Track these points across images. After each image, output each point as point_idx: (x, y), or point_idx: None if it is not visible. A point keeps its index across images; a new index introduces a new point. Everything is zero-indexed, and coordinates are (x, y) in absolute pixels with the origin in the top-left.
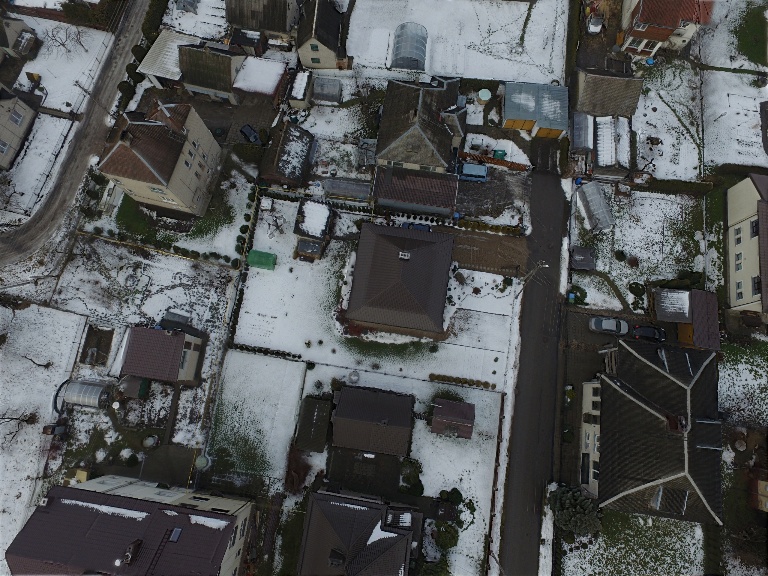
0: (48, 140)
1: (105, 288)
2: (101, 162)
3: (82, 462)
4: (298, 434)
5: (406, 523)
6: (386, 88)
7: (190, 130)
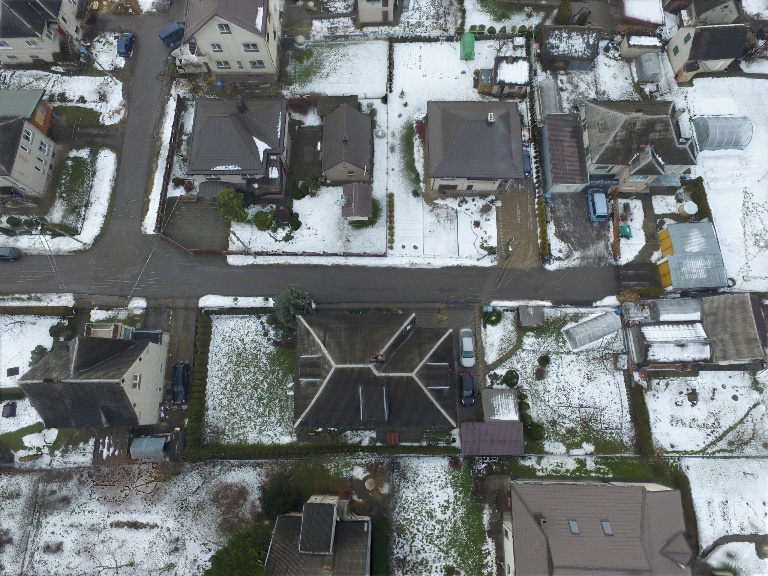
0: None
1: None
2: None
3: None
4: (329, 96)
5: (271, 174)
6: None
7: None
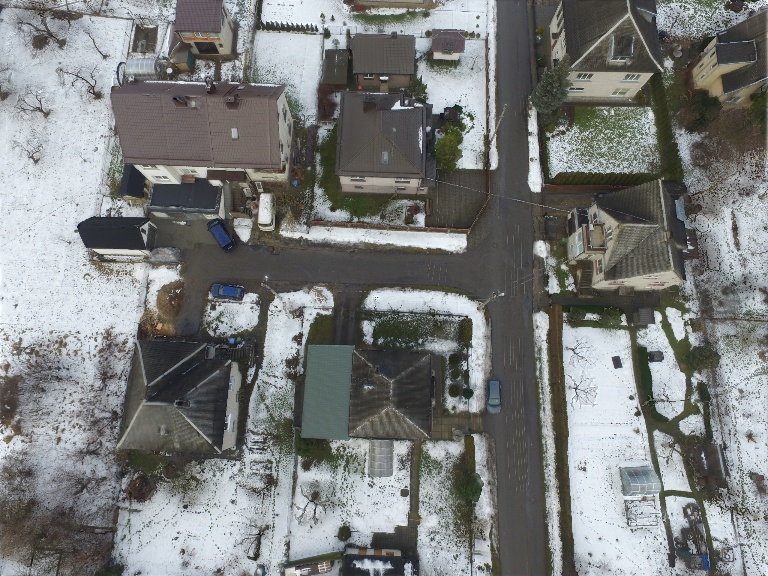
0: None
1: None
2: None
3: None
4: (324, 74)
5: None
6: None
7: None
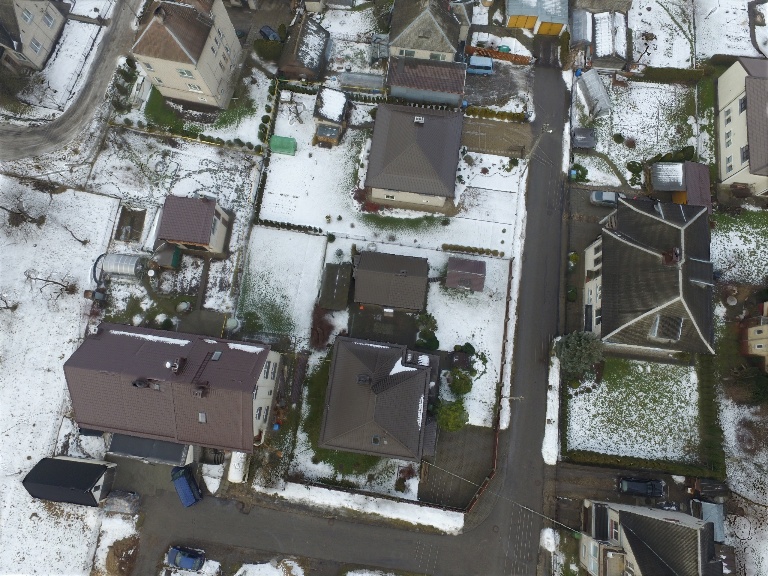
0: (78, 43)
1: (136, 173)
2: (134, 43)
3: None
4: (322, 295)
5: (424, 364)
6: None
7: (216, 16)
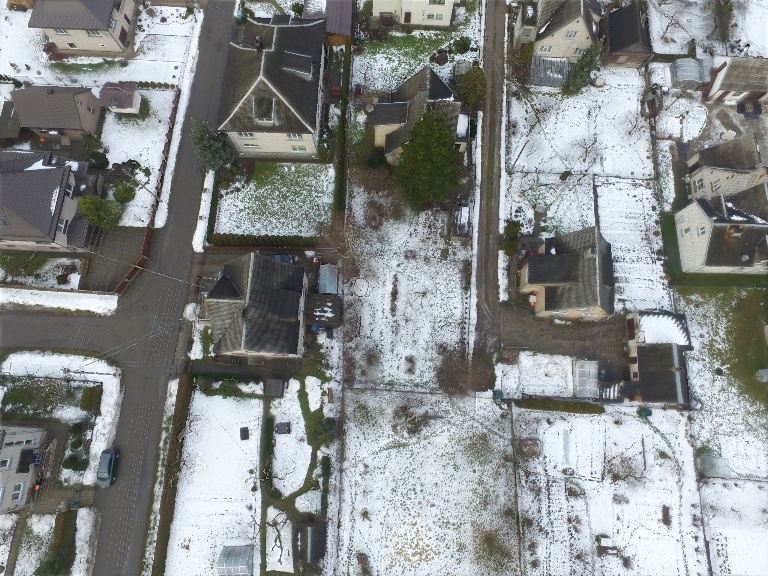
0: None
1: None
2: None
3: None
4: None
5: (73, 169)
6: None
7: None
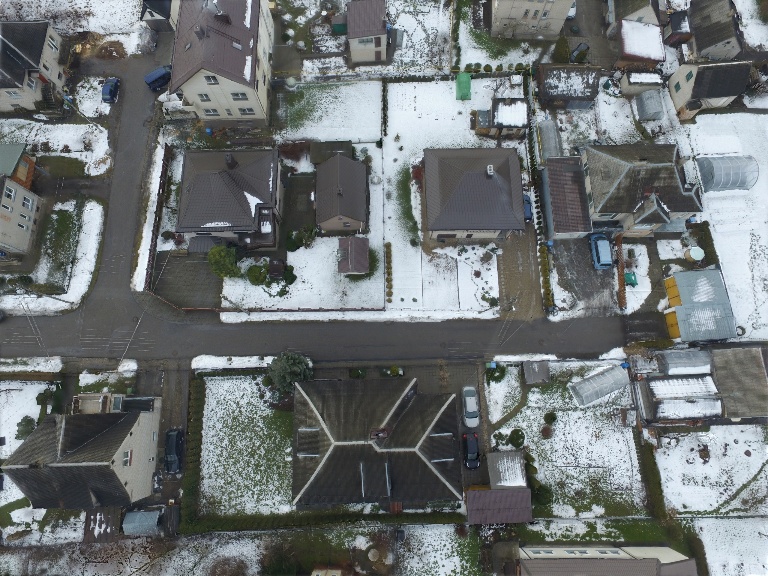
0: None
1: None
2: None
3: (281, 7)
4: (322, 142)
5: (264, 229)
6: (666, 144)
7: None
